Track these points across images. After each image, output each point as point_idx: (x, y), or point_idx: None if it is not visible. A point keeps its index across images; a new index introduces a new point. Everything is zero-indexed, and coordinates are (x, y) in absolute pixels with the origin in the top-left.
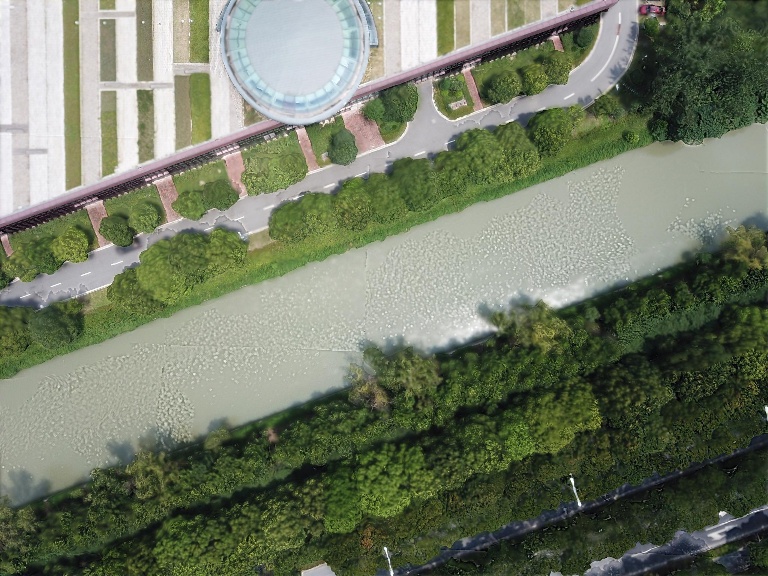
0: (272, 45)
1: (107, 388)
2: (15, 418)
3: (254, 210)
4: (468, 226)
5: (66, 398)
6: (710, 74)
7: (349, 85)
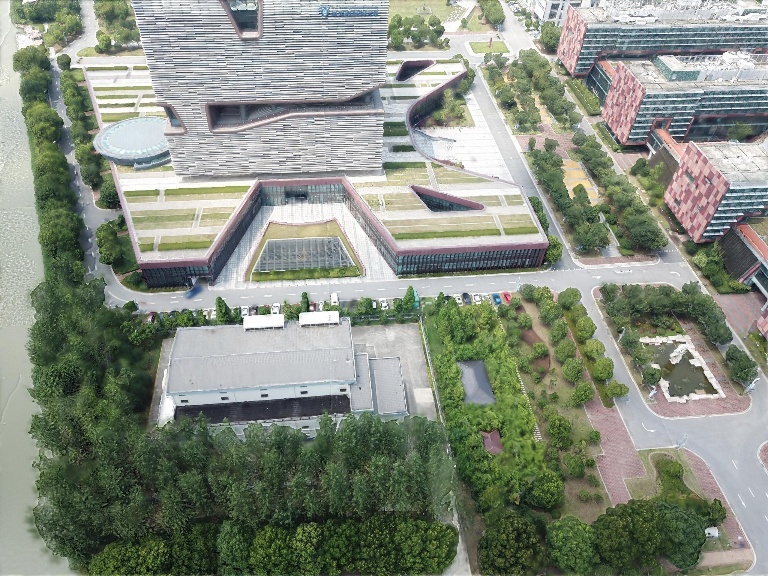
0: (139, 128)
1: (4, 128)
2: (3, 103)
3: (74, 158)
4: (32, 246)
5: (6, 117)
6: (51, 276)
7: (110, 153)
